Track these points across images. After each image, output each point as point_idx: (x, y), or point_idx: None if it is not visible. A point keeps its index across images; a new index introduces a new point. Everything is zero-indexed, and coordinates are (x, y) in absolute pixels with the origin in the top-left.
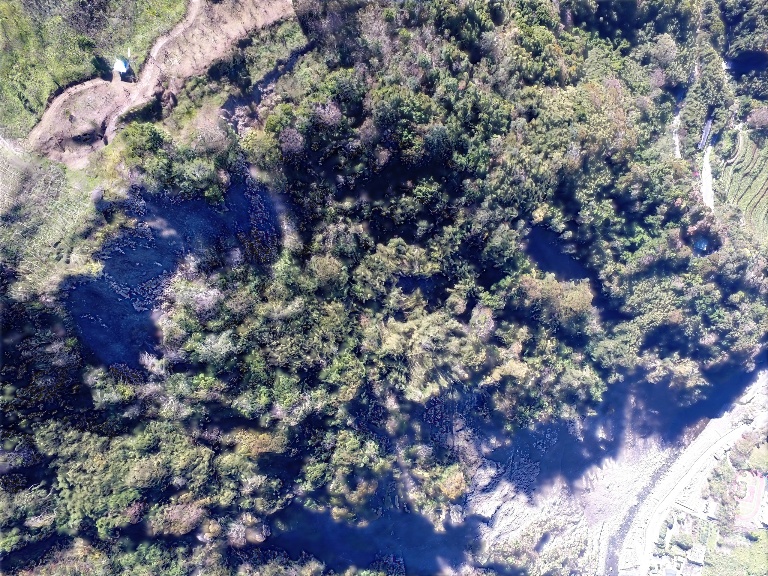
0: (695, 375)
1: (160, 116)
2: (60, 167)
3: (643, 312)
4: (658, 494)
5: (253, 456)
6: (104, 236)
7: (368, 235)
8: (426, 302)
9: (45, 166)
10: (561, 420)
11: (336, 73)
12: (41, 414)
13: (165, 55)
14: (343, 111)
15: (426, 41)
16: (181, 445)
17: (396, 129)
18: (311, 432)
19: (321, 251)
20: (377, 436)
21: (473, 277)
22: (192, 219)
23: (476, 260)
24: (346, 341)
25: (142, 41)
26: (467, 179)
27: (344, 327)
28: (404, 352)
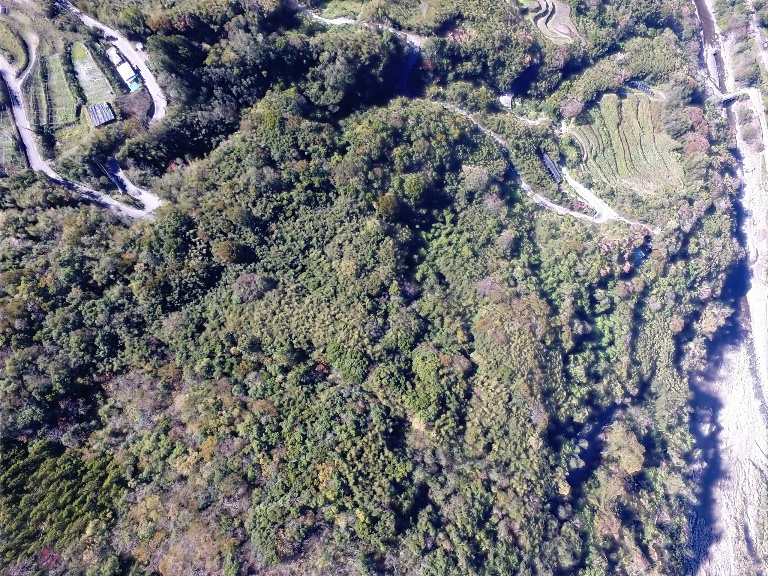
0: None
1: None
2: None
3: (657, 356)
4: (767, 382)
5: None
6: None
7: None
8: None
9: None
10: None
11: None
12: None
13: None
14: None
15: None
16: None
17: None
18: None
19: None
20: None
21: None
22: None
23: None
24: None
25: None
26: None
27: None
28: None
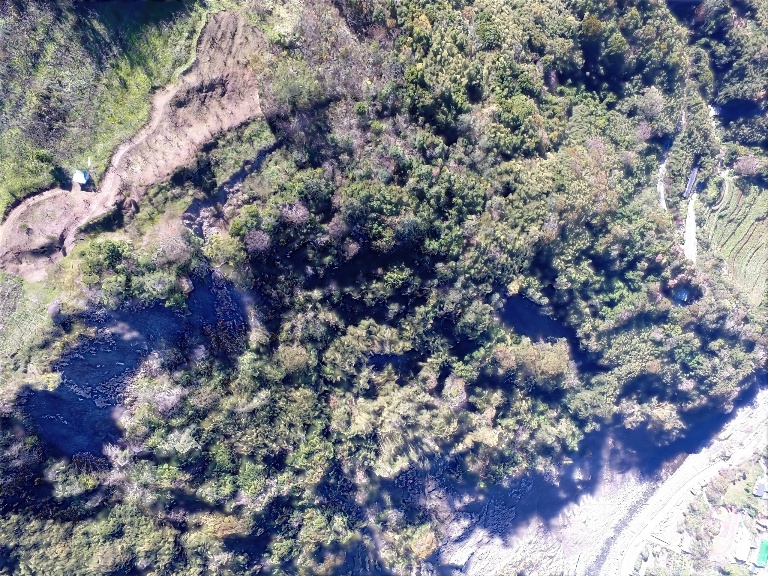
0: (673, 417)
1: (121, 224)
2: (17, 280)
3: (621, 364)
4: (635, 527)
5: (219, 536)
6: (63, 345)
7: (339, 318)
8: (398, 376)
9: (2, 278)
10: (536, 470)
11: (304, 174)
12: (2, 507)
13: (127, 163)
14: (311, 209)
15: (400, 129)
16: (146, 527)
17: (366, 223)
18: (278, 512)
19: (289, 340)
20: (347, 505)
21: (446, 350)
22: (155, 318)
23: (450, 332)
24: (314, 424)
25: (103, 150)
26: (439, 263)
27: (312, 411)
28: (374, 430)
